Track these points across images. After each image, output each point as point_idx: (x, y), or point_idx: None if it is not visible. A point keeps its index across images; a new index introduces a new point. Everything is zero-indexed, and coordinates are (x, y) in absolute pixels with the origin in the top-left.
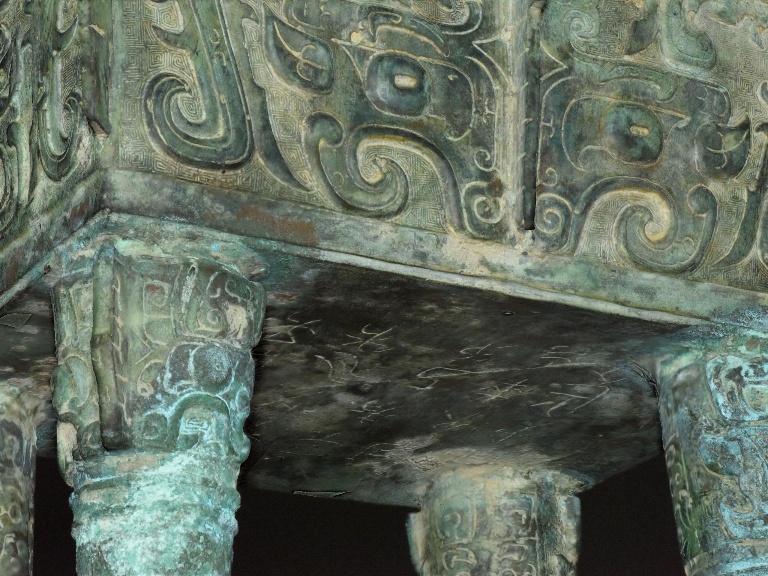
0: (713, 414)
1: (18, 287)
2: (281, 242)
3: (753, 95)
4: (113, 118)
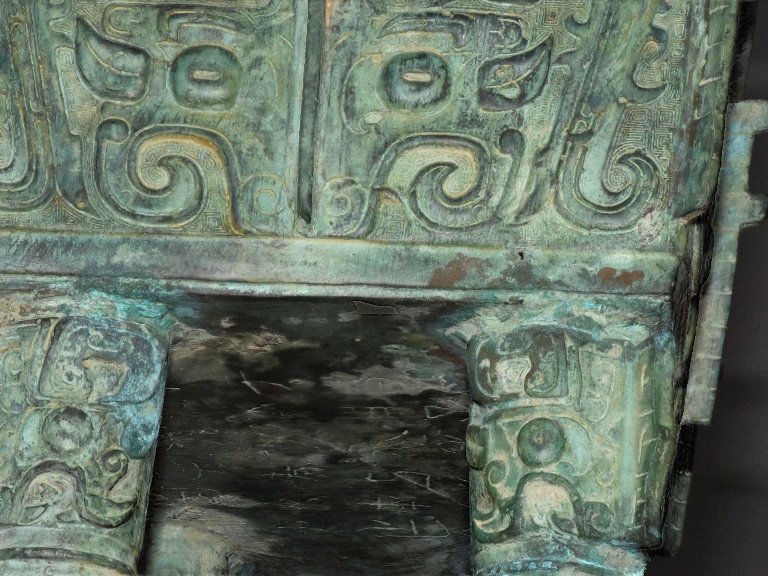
0: None
1: (443, 293)
2: None
3: None
4: None
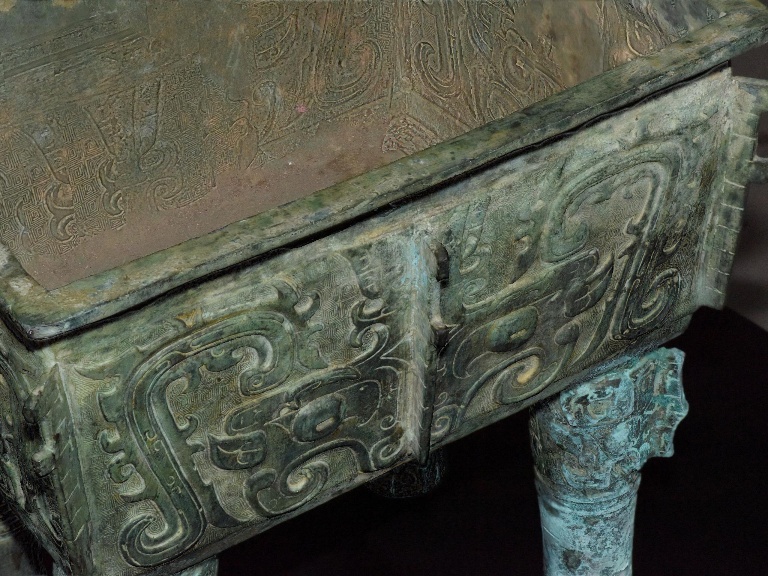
0: None
1: None
2: None
3: (619, 235)
4: (97, 561)
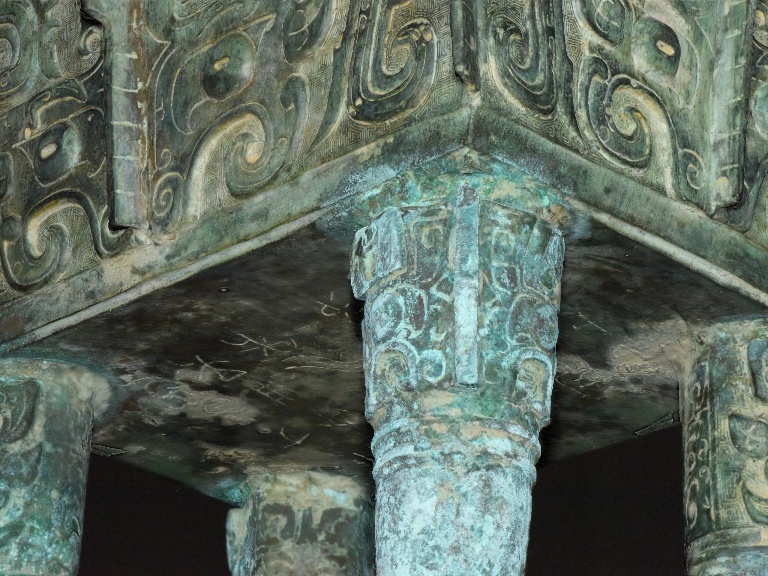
0: None
1: None
2: (7, 343)
3: None
4: None
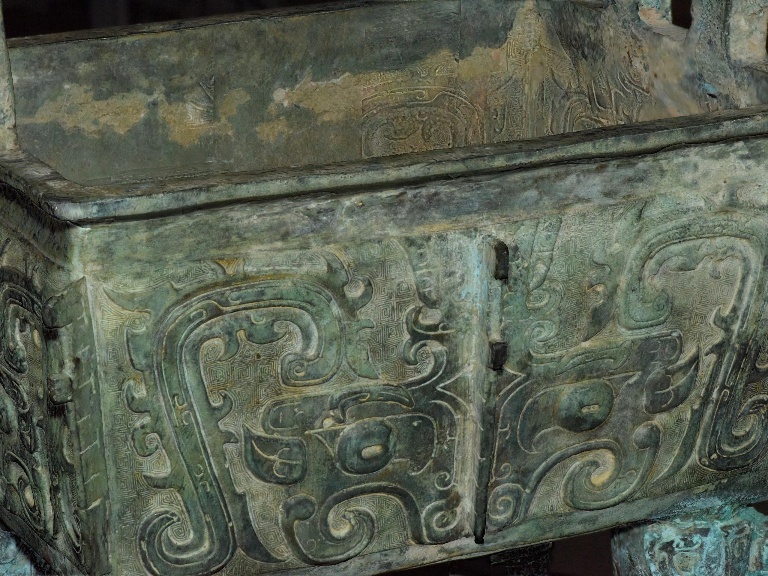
0: (647, 568)
1: None
2: None
3: (706, 324)
4: (113, 558)
